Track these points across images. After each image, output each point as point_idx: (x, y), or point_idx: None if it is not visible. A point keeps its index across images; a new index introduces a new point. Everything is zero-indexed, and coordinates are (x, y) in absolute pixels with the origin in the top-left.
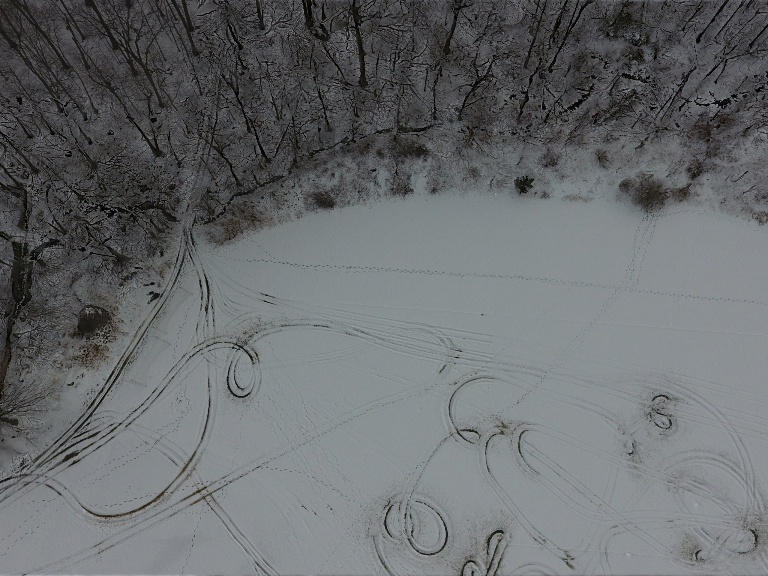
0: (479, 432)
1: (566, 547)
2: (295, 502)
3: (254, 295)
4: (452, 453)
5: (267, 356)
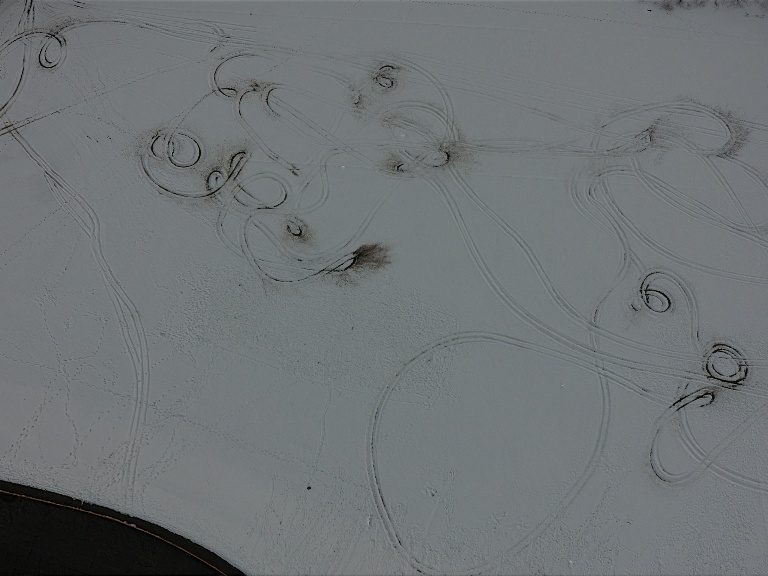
0: (236, 90)
1: (294, 162)
2: (82, 134)
3: (68, 2)
4: (212, 103)
5: (73, 41)
